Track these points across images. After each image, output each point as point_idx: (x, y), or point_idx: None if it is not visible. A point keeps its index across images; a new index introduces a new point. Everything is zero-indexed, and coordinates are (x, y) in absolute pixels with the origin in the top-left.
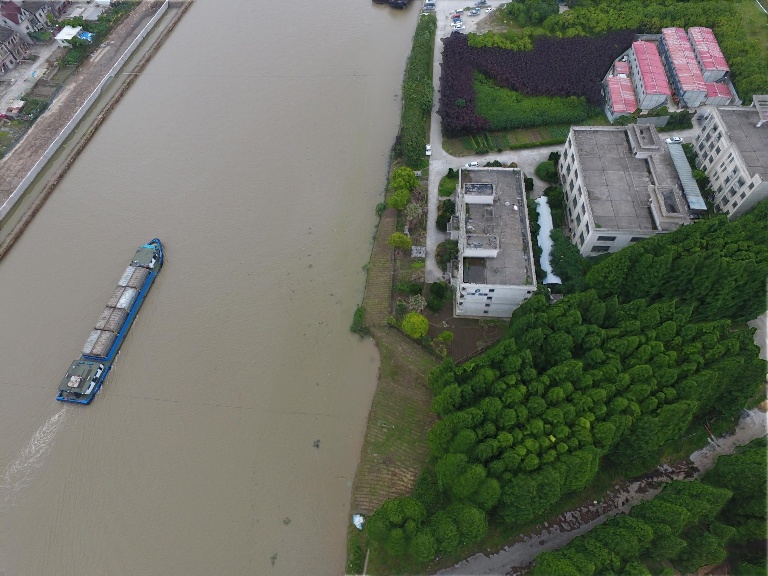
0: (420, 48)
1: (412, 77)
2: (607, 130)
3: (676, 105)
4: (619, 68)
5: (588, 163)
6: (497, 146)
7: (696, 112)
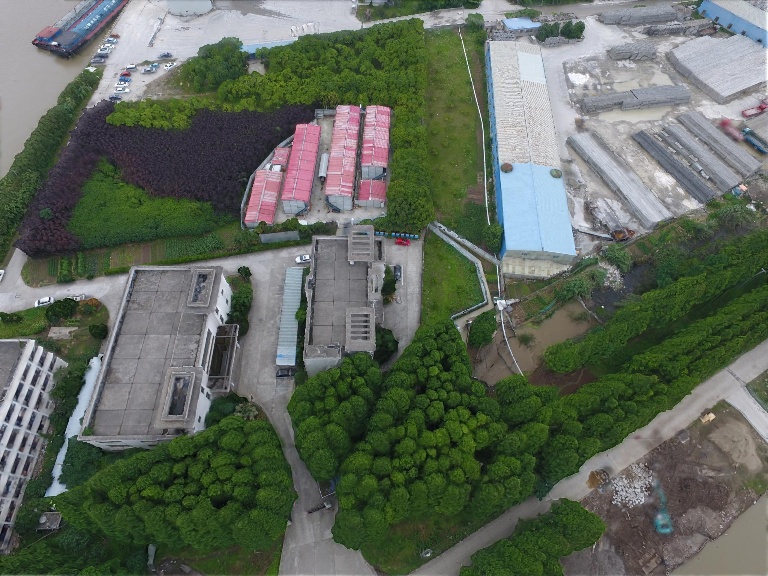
0: (43, 125)
1: (9, 170)
2: (178, 269)
3: (327, 207)
4: (276, 157)
5: (132, 322)
6: (89, 271)
7: (333, 223)
